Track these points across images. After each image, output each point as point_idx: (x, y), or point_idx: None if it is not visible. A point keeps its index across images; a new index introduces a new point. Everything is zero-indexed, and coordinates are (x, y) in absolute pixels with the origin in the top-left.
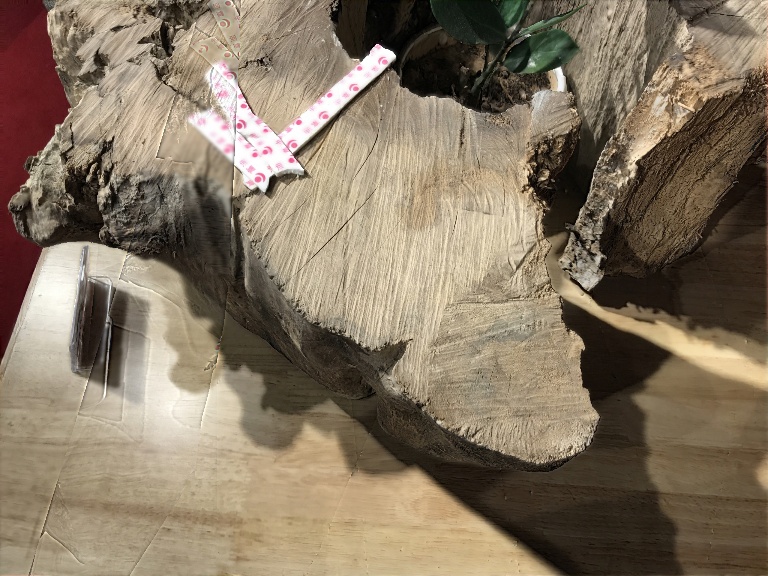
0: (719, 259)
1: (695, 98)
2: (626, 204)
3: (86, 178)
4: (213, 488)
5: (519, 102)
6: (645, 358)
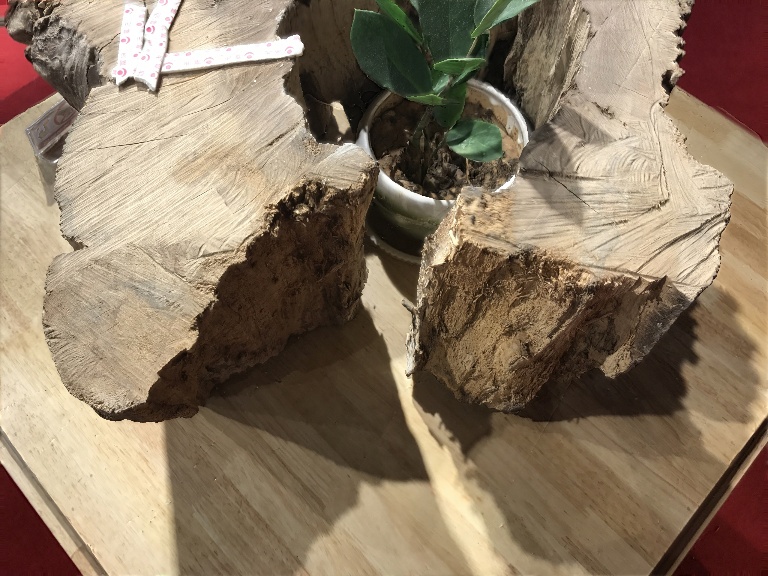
0: (554, 445)
1: (459, 233)
2: (438, 311)
3: (39, 3)
4: (34, 294)
5: (476, 182)
6: (404, 464)
